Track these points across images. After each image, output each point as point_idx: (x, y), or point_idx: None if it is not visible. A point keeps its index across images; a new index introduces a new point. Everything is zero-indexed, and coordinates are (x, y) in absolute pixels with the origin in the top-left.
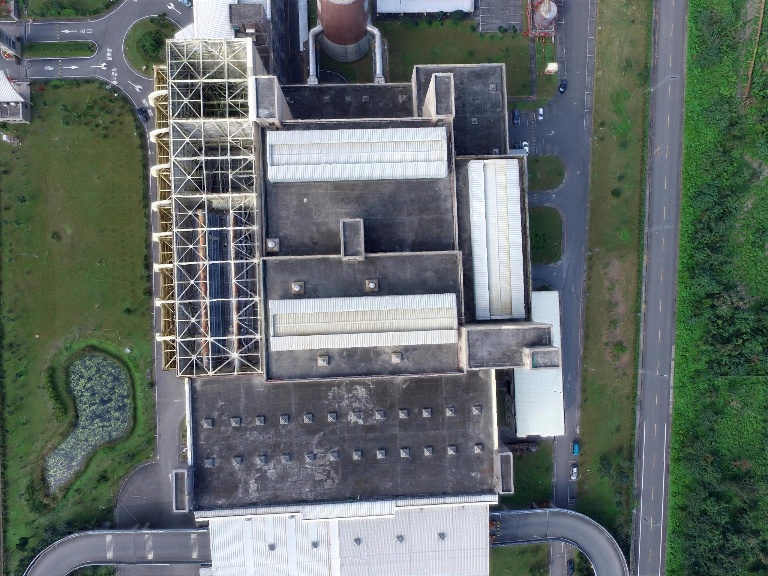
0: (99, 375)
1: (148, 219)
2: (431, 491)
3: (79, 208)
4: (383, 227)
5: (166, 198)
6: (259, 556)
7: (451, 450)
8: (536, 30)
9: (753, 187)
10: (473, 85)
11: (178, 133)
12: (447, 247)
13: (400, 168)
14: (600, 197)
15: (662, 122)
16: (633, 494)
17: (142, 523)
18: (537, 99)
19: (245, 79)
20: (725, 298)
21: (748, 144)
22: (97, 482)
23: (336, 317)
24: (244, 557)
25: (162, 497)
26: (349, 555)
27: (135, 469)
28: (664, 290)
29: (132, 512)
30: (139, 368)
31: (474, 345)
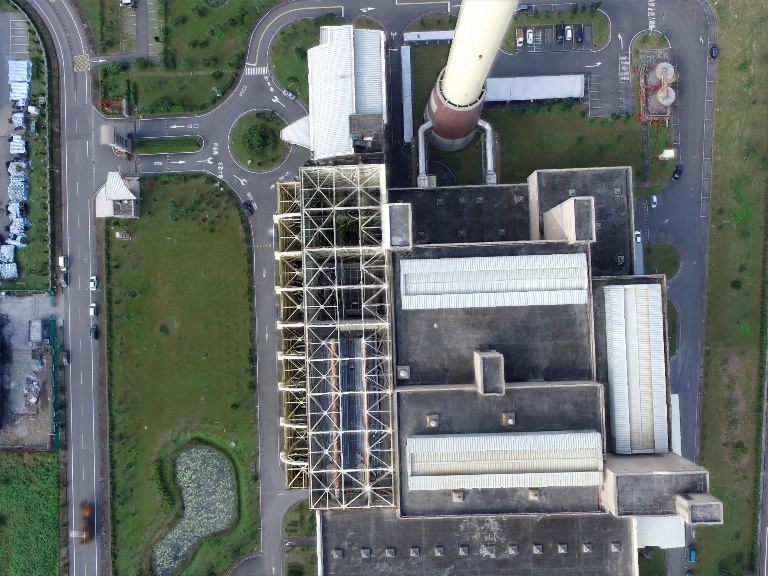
0: (204, 467)
1: (252, 312)
2: None
3: (186, 301)
4: (516, 353)
5: (289, 315)
6: None
7: None
8: (650, 115)
9: None
10: (596, 188)
11: (311, 262)
12: (583, 374)
13: (538, 297)
14: (718, 289)
15: None
16: None
17: None
18: (650, 186)
19: (378, 206)
20: None
21: None
22: None
23: (475, 456)
24: None
25: None
26: None
27: (239, 562)
28: None
29: None
30: (244, 461)
31: (623, 491)
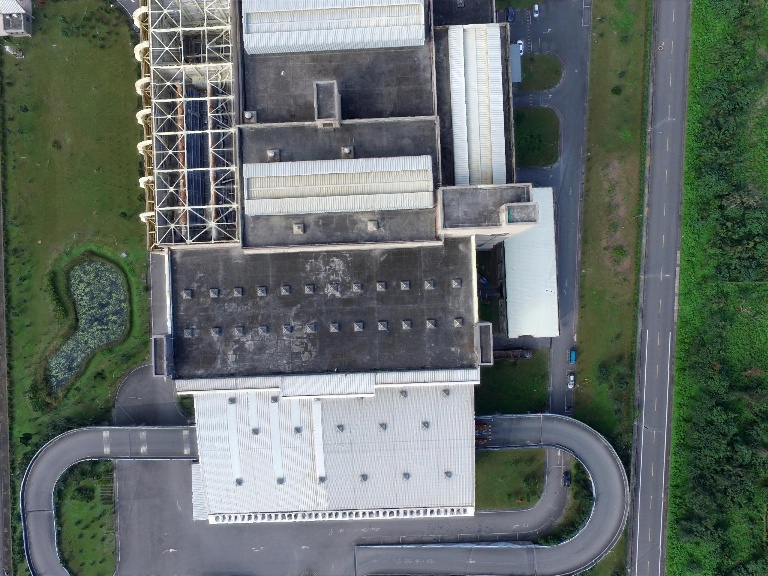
0: (97, 280)
1: None
2: (410, 365)
3: (78, 117)
4: (361, 98)
5: None
6: (243, 440)
7: (430, 323)
8: None
9: (767, 82)
10: None
11: (156, 5)
12: None
13: (376, 33)
14: (599, 96)
15: (667, 16)
16: (634, 405)
17: (138, 423)
18: None
19: None
20: (735, 197)
21: (762, 36)
22: (94, 378)
23: (310, 181)
24: (229, 441)
25: (157, 399)
26: (332, 442)
27: (132, 371)
28: (669, 193)
29: (129, 413)
30: (135, 272)
31: (449, 205)
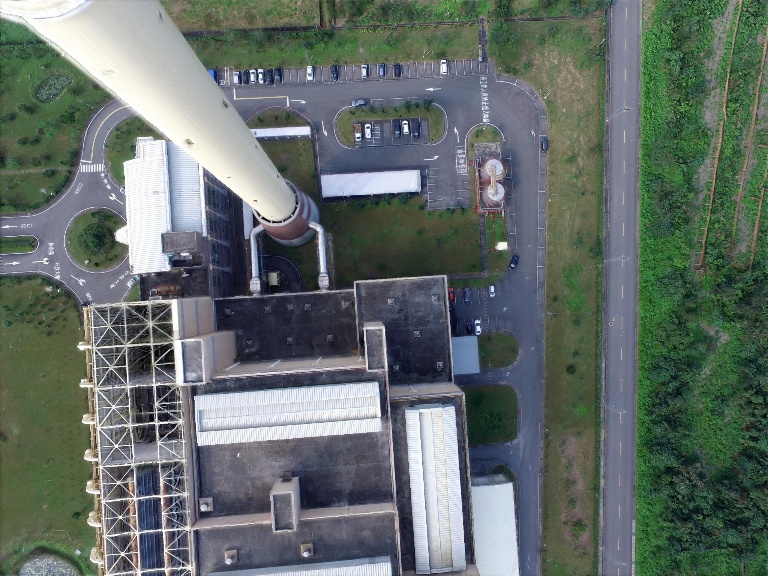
0: None
1: None
2: None
3: (24, 407)
4: (319, 478)
5: None
6: None
7: None
8: None
9: None
10: (415, 297)
11: (104, 401)
12: (385, 495)
13: (332, 427)
14: (555, 373)
15: (616, 293)
16: None
17: None
18: (488, 275)
19: (171, 342)
20: (684, 475)
21: (704, 312)
22: None
23: None
24: None
25: None
26: None
27: None
28: (623, 464)
29: None
30: (90, 569)
31: None
